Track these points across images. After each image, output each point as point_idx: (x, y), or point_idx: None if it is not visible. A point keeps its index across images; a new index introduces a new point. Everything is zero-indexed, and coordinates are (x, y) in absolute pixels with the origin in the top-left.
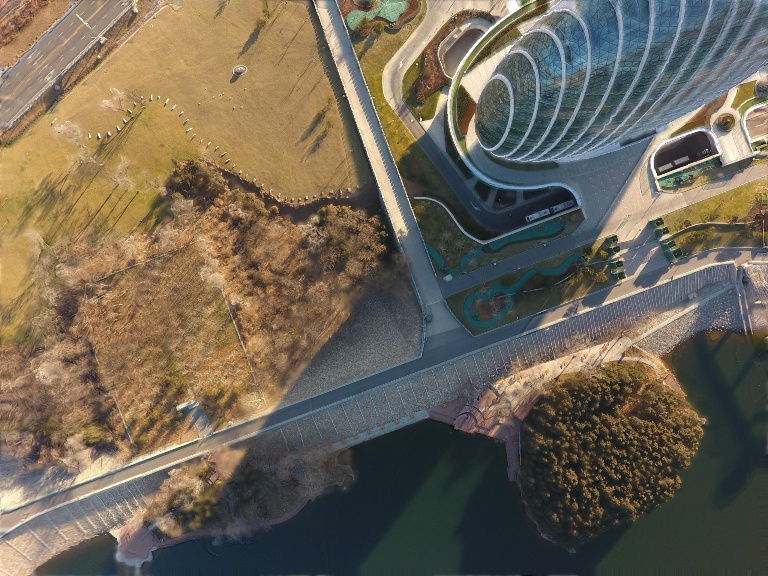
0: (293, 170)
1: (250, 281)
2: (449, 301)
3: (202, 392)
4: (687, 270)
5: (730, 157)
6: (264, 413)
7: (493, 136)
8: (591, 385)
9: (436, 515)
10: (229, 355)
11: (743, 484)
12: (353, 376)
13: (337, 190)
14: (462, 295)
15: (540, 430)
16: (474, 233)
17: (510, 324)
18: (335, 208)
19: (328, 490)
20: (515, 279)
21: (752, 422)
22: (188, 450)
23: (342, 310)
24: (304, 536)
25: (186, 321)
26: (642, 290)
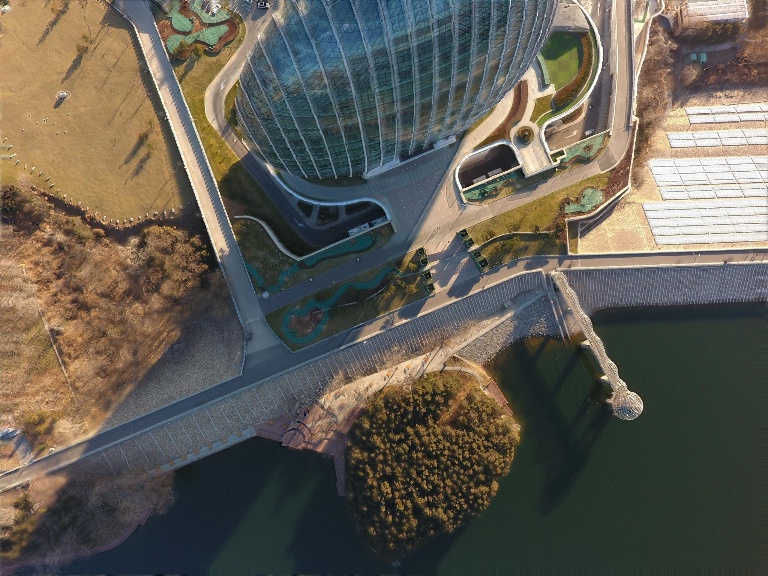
0: (117, 193)
1: (74, 305)
2: (268, 318)
3: (23, 419)
4: (498, 279)
5: (531, 168)
6: (85, 438)
7: (259, 156)
8: (404, 396)
9: (268, 534)
10: (49, 380)
11: (568, 488)
12: (175, 397)
13: (161, 211)
14: (281, 311)
15: (357, 443)
16: (296, 249)
17: (328, 339)
18: (159, 229)
19: (164, 513)
20: (330, 294)
21: (574, 426)
22: (8, 479)
23: (172, 330)
24: (134, 562)
25: (6, 348)
26: (455, 300)
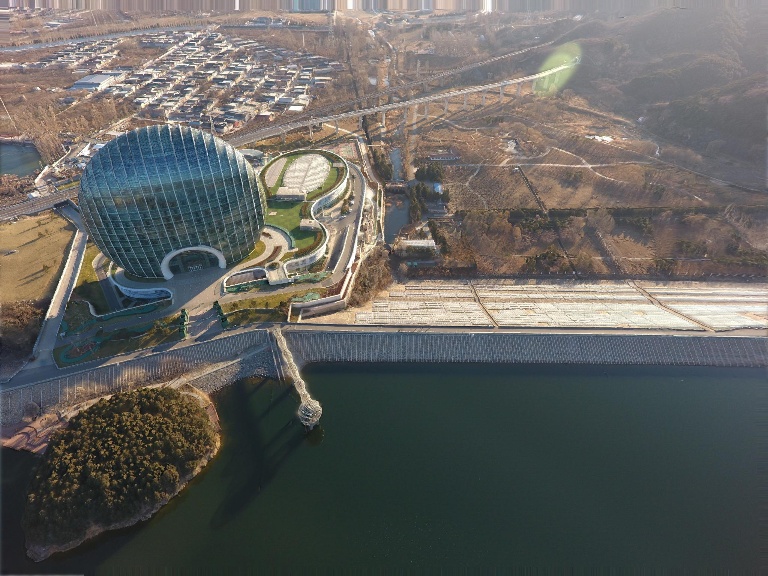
0: (7, 291)
1: None
2: (56, 349)
3: None
4: (234, 333)
5: (273, 279)
6: None
7: None
8: (125, 392)
9: None
10: None
11: (253, 499)
12: None
13: (28, 300)
14: (67, 346)
15: None
16: None
17: (92, 362)
18: None
19: None
20: None
21: (272, 443)
22: None
23: None
24: None
25: None
26: (198, 343)
